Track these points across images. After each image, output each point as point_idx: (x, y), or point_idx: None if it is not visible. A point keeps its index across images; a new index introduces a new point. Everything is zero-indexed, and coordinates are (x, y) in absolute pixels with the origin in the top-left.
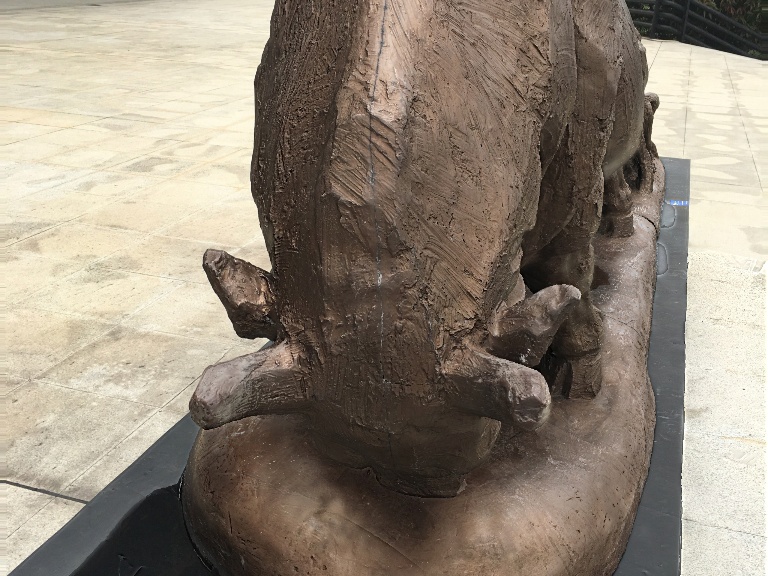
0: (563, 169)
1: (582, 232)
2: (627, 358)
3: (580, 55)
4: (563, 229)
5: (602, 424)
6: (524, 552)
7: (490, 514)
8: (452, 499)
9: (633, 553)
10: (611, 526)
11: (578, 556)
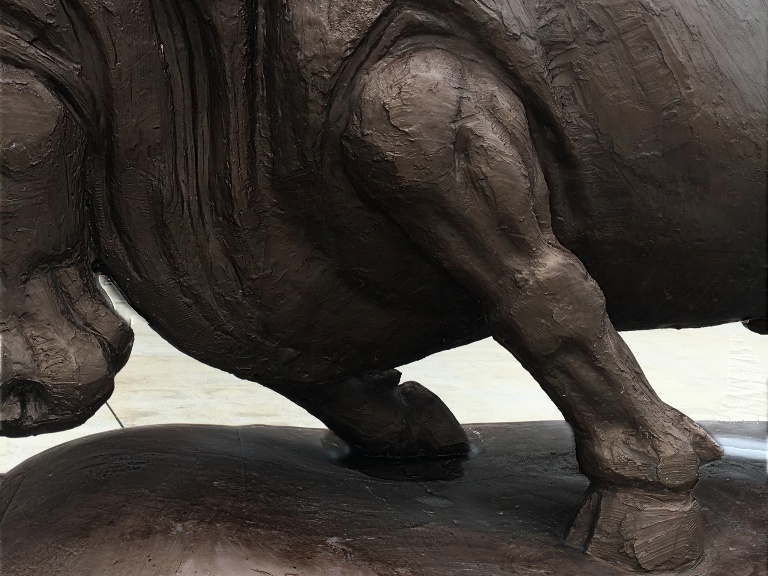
0: (283, 27)
1: (372, 150)
2: None
3: None
4: (343, 143)
5: None
6: None
7: (116, 523)
8: (107, 494)
9: None
10: None
11: None
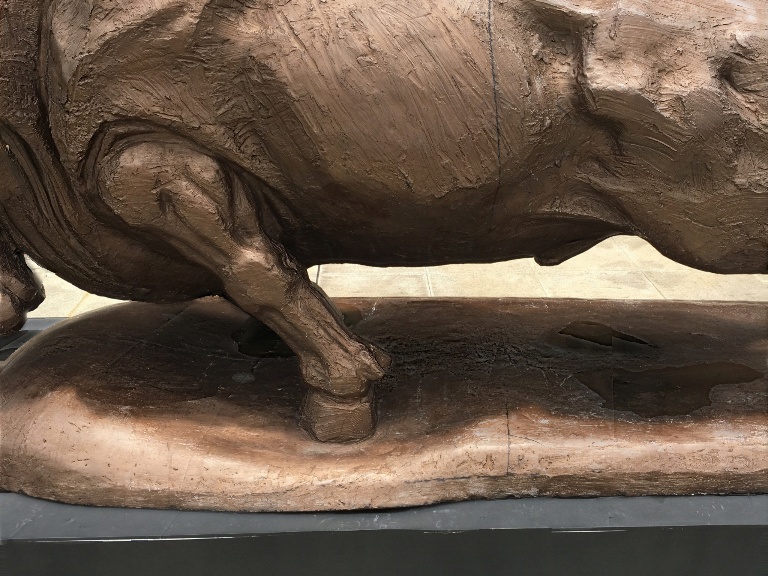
0: None
1: None
2: (426, 449)
3: (51, 47)
4: None
5: (260, 449)
6: (7, 418)
7: (27, 387)
8: None
9: (98, 512)
10: (82, 469)
11: (27, 452)
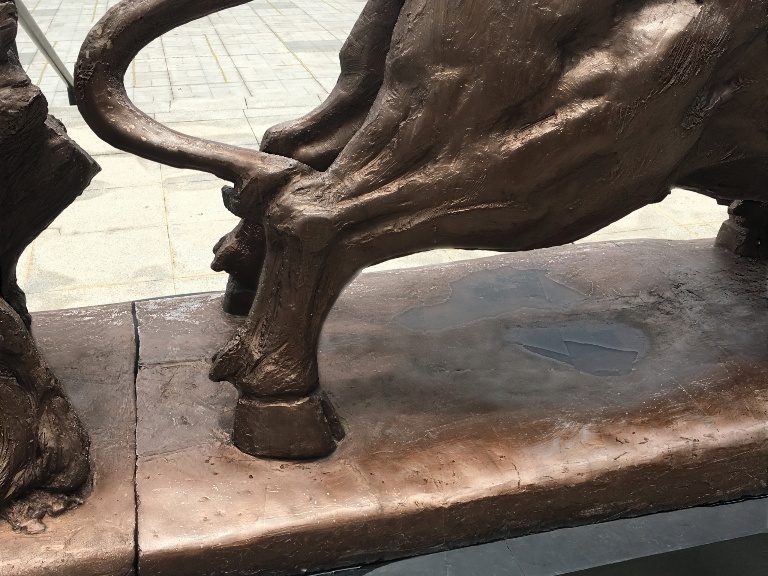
0: None
1: None
2: None
3: None
4: None
5: None
6: None
7: None
8: None
9: None
10: None
11: None
